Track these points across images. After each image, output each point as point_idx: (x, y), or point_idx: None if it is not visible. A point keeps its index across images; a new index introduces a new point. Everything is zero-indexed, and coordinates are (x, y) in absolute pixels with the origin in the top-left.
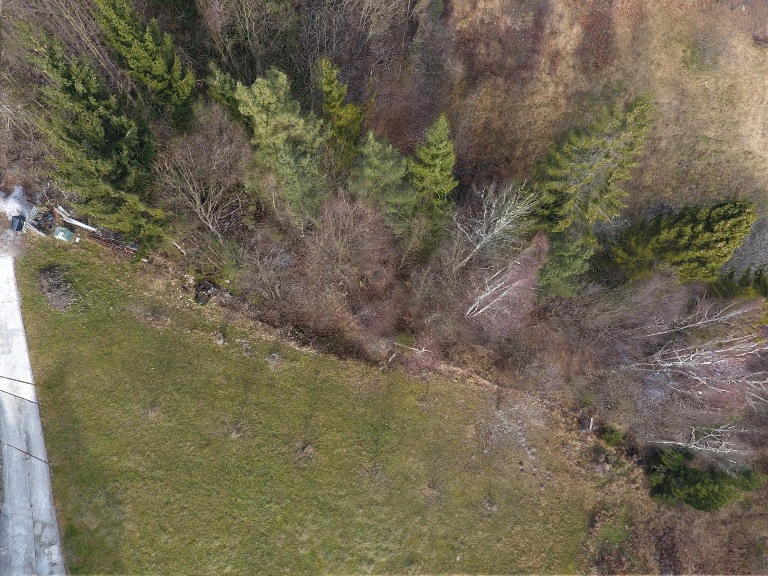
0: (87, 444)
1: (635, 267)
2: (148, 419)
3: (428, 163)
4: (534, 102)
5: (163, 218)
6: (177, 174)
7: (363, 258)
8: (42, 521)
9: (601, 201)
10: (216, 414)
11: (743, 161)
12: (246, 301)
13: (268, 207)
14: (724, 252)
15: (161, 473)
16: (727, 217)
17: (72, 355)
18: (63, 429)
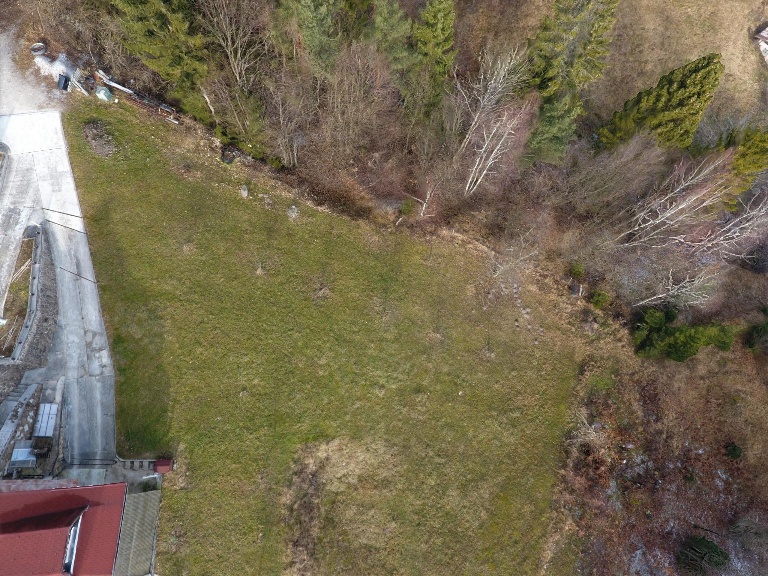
0: (130, 269)
1: (619, 143)
2: (183, 252)
3: (431, 22)
4: (528, 24)
5: (199, 55)
6: (214, 5)
7: (371, 140)
8: (92, 331)
9: (586, 63)
10: (243, 254)
11: (724, 83)
12: (267, 164)
13: (289, 61)
14: (696, 108)
15: (196, 297)
16: (698, 71)
17: (115, 195)
18: (109, 255)
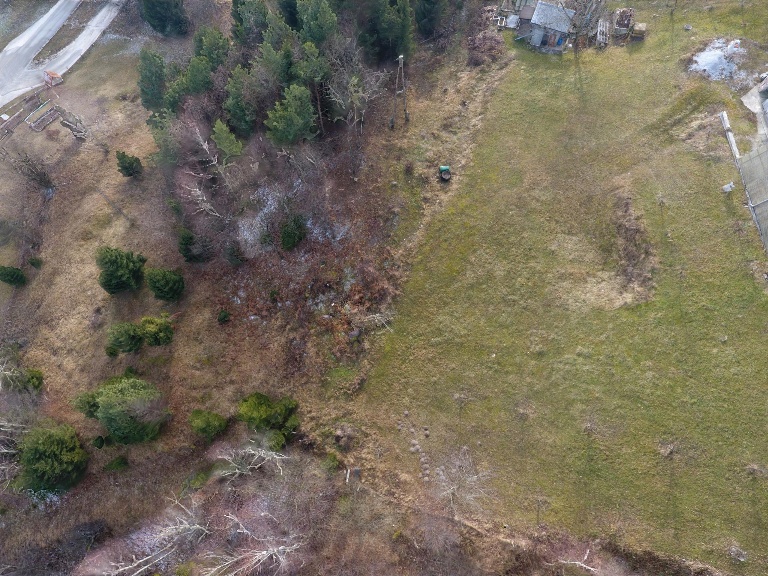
0: None
1: None
2: None
3: None
4: None
5: None
6: None
7: None
8: None
9: None
10: None
11: None
12: None
13: None
14: None
15: None
16: None
17: None
18: None
